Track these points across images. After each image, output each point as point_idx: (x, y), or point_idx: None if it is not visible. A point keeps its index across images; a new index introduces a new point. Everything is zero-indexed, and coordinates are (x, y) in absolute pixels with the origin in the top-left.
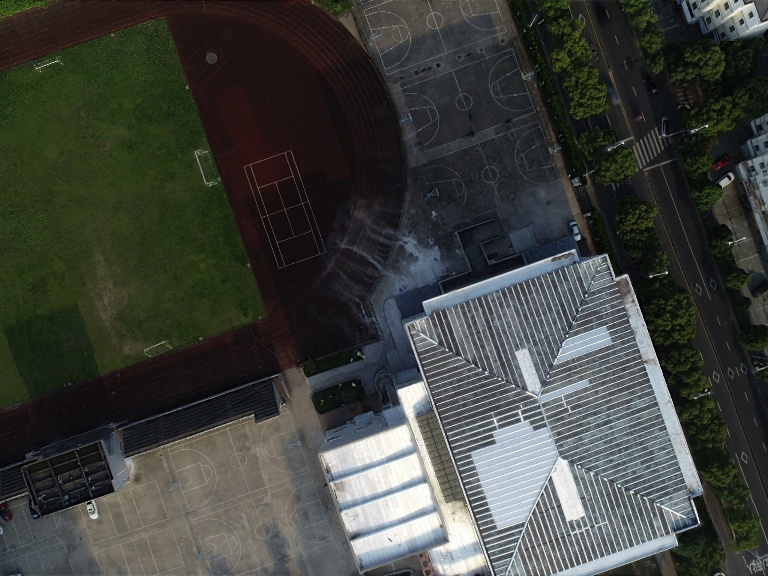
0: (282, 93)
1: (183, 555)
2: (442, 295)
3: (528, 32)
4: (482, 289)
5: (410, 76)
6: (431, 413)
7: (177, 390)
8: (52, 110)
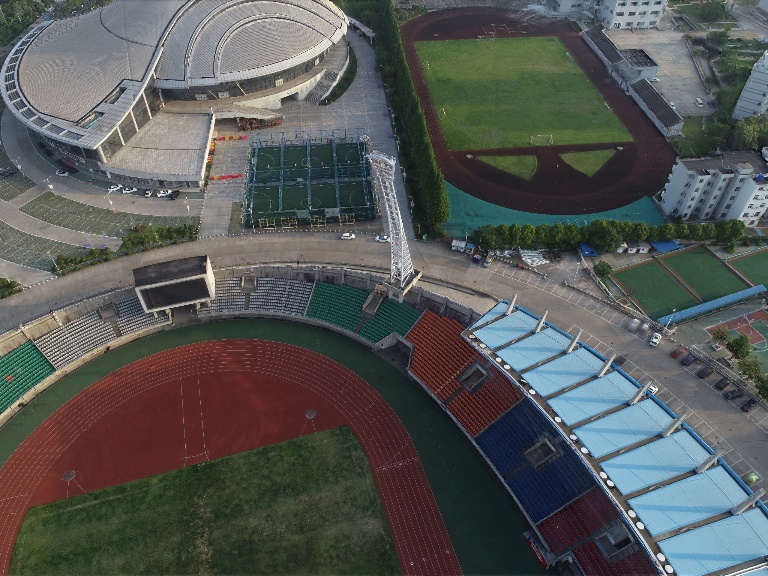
0: (456, 24)
1: (674, 64)
2: None
3: None
4: None
5: (456, 3)
6: None
7: (590, 57)
8: None
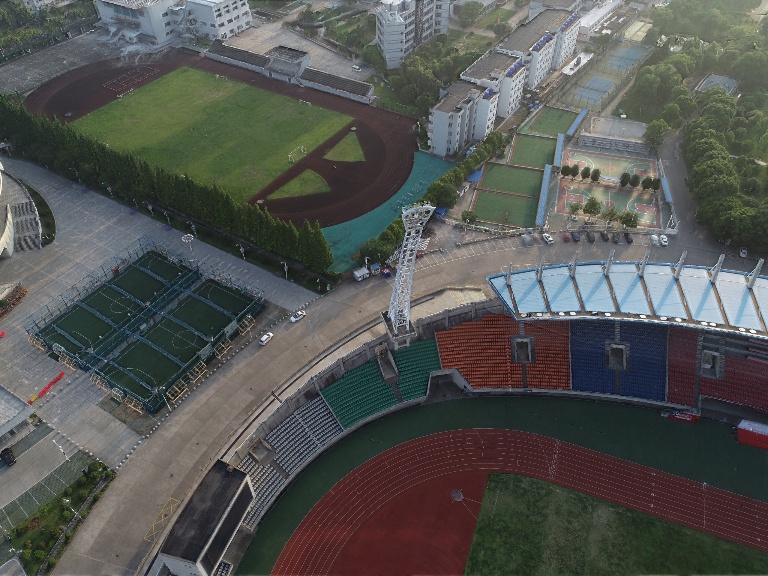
0: (74, 95)
1: None
2: (130, 8)
3: (7, 56)
4: (122, 4)
5: None
6: (178, 3)
7: None
8: (129, 139)
